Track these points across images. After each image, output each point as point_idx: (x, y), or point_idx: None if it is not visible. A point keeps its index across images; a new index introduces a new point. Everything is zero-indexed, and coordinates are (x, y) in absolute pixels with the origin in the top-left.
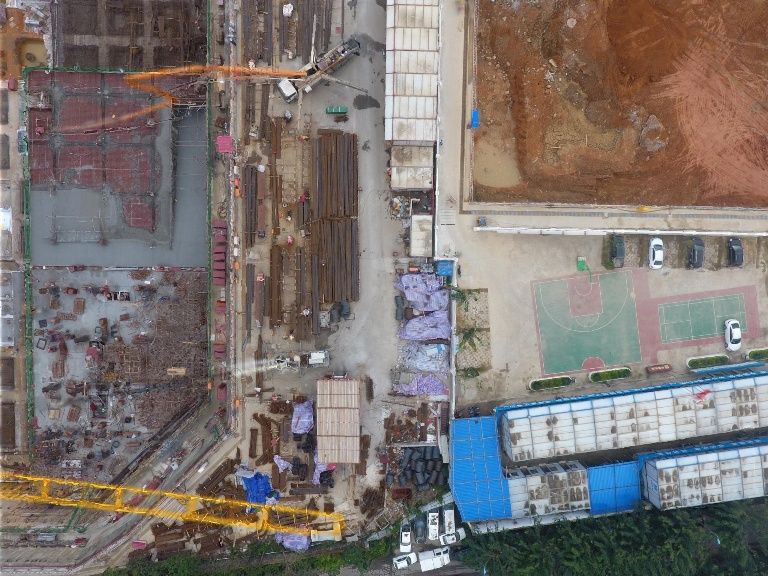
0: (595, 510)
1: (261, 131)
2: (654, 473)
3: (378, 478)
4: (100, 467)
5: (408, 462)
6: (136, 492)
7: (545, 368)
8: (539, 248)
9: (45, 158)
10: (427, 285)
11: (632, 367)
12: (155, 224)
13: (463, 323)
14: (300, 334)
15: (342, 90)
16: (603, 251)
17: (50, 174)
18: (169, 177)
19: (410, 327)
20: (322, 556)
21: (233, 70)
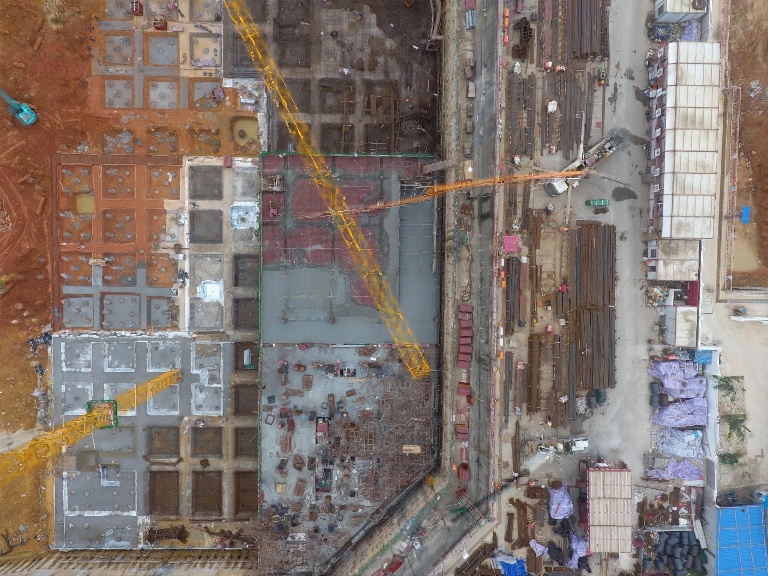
0: None
1: (522, 223)
2: None
3: (631, 562)
4: (325, 541)
5: (663, 546)
6: (376, 570)
7: None
8: None
9: (277, 239)
10: (685, 373)
11: None
12: (381, 302)
13: (719, 410)
14: (556, 420)
15: (601, 182)
16: None
17: (281, 254)
18: (396, 256)
19: (668, 414)
20: None
21: (497, 165)
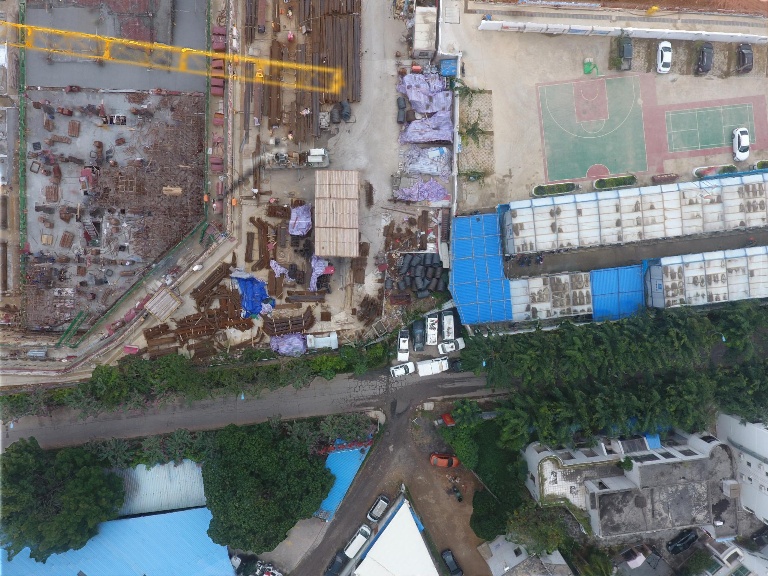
0: (597, 316)
1: None
2: (659, 271)
3: (376, 287)
4: (93, 295)
5: (407, 269)
6: (129, 310)
7: (549, 175)
8: (545, 50)
9: None
10: (430, 85)
11: (638, 176)
12: (153, 46)
13: None
14: (299, 136)
15: None
16: (610, 55)
17: None
18: None
19: (412, 128)
20: (318, 357)
21: None
